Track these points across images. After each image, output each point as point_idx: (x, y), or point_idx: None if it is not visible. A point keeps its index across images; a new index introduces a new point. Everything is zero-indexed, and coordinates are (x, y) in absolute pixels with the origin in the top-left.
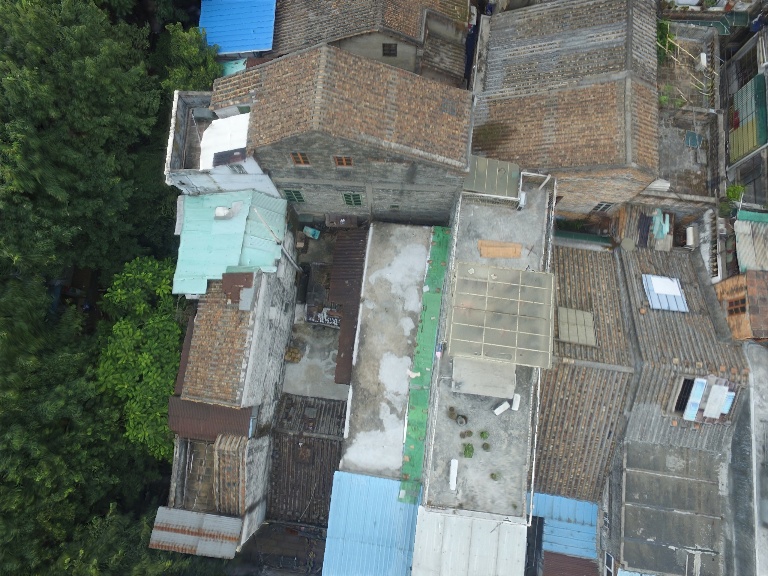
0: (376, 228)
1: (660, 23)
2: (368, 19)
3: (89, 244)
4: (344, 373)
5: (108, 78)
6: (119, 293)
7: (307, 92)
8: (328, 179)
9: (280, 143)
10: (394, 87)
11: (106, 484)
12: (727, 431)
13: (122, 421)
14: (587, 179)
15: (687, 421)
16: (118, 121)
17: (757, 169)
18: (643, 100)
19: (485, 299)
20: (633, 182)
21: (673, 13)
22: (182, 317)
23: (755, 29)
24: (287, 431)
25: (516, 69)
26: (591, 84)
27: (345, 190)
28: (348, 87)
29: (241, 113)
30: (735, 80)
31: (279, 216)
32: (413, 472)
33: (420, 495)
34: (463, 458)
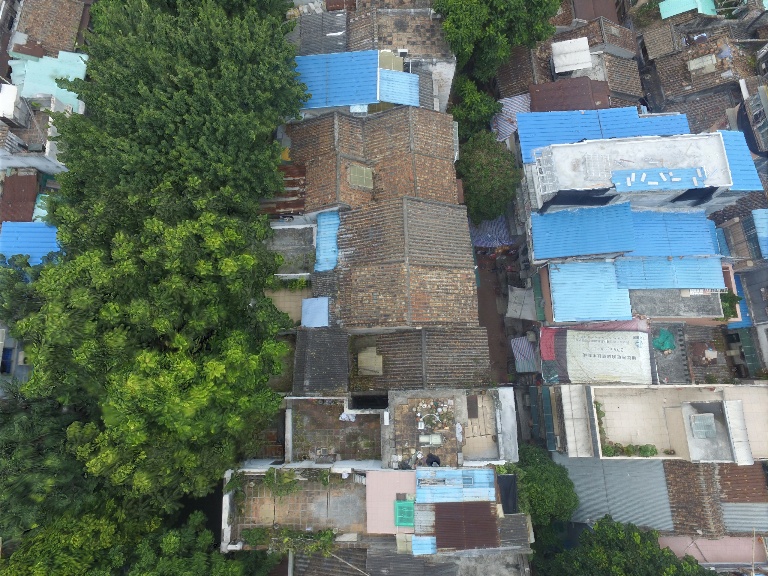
0: None
1: None
2: None
3: None
4: (8, 39)
5: None
6: None
7: None
8: None
9: None
10: None
11: None
12: None
13: None
14: None
15: None
16: None
17: None
18: None
19: None
20: None
21: None
22: None
23: None
24: None
25: None
26: None
27: None
28: None
29: None
30: None
31: None
32: None
33: None
34: None
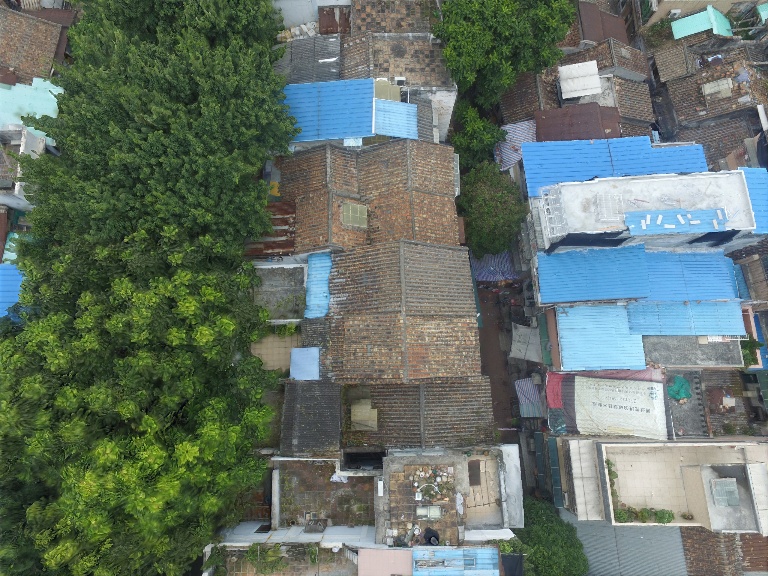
0: None
1: None
2: None
3: None
4: None
5: None
6: None
7: None
8: None
9: None
10: None
11: None
12: None
13: None
14: None
15: None
16: None
17: None
18: None
19: None
20: None
21: None
22: None
23: None
24: None
25: None
26: None
27: None
28: None
29: None
30: None
31: None
32: None
33: None
34: None
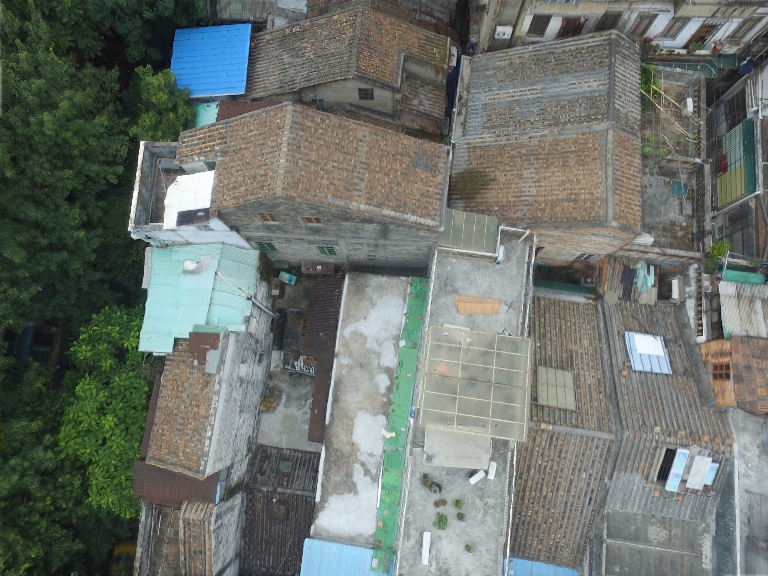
0: (352, 279)
1: (645, 68)
2: (342, 65)
3: (56, 293)
4: (317, 431)
5: (69, 132)
6: (84, 350)
7: (271, 154)
8: (299, 234)
9: (244, 206)
10: (364, 145)
11: (70, 548)
12: (711, 501)
13: (85, 485)
14: (567, 234)
15: (669, 491)
16: (83, 171)
17: (746, 216)
18: (625, 152)
19: (459, 366)
20: (615, 238)
21: (659, 56)
22: (150, 373)
23: (744, 71)
24: (260, 487)
25: (496, 114)
26: (572, 134)
27: (318, 243)
28: (315, 148)
29: (208, 167)
30: (724, 121)
31: (250, 268)
32: (386, 539)
33: (393, 564)
34: (437, 528)
